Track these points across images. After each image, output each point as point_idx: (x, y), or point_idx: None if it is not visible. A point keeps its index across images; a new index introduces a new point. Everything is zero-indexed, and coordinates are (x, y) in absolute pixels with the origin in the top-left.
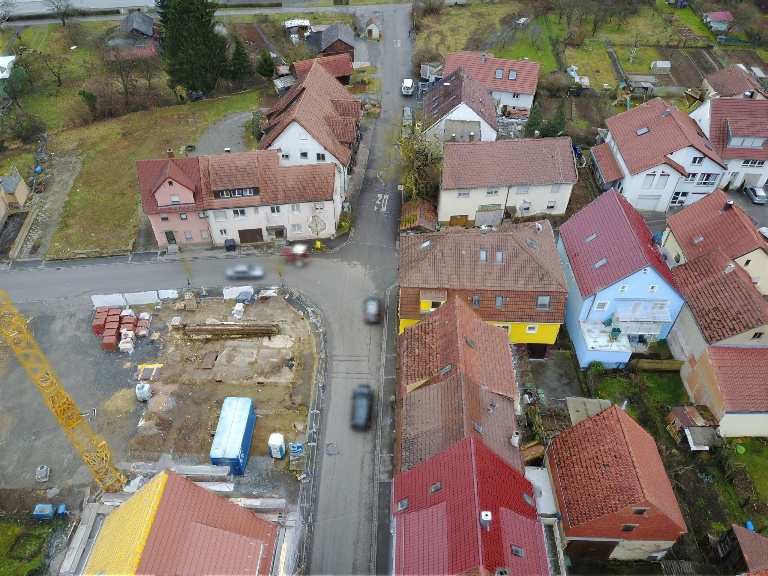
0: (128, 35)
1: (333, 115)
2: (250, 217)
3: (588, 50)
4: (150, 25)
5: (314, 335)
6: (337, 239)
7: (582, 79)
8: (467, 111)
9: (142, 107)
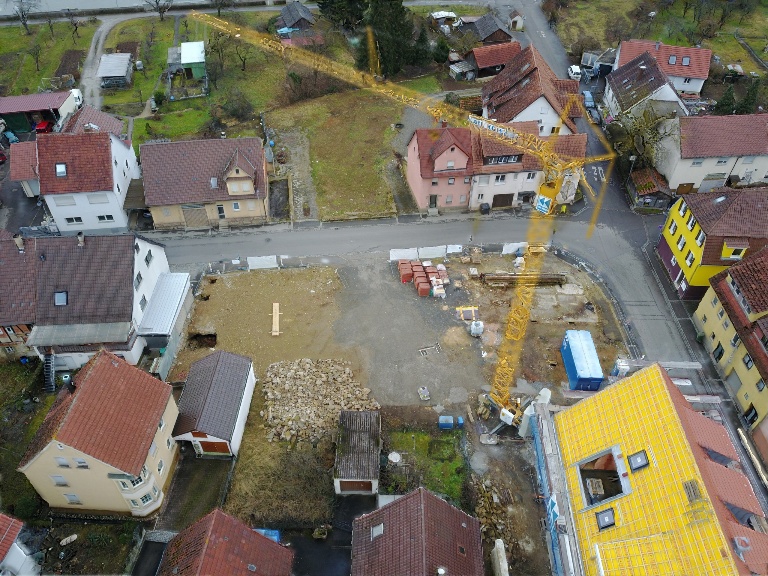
0: (326, 22)
1: (557, 93)
2: (508, 182)
3: (722, 42)
4: (310, 15)
5: (597, 284)
6: (576, 205)
7: (735, 67)
8: (669, 92)
9: (337, 89)
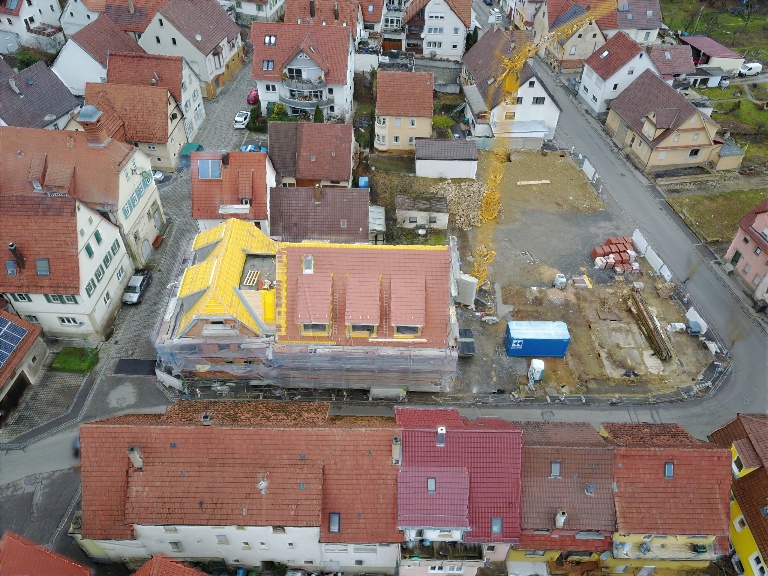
0: None
1: None
2: None
3: None
4: None
5: (676, 391)
6: None
7: None
8: None
9: None
